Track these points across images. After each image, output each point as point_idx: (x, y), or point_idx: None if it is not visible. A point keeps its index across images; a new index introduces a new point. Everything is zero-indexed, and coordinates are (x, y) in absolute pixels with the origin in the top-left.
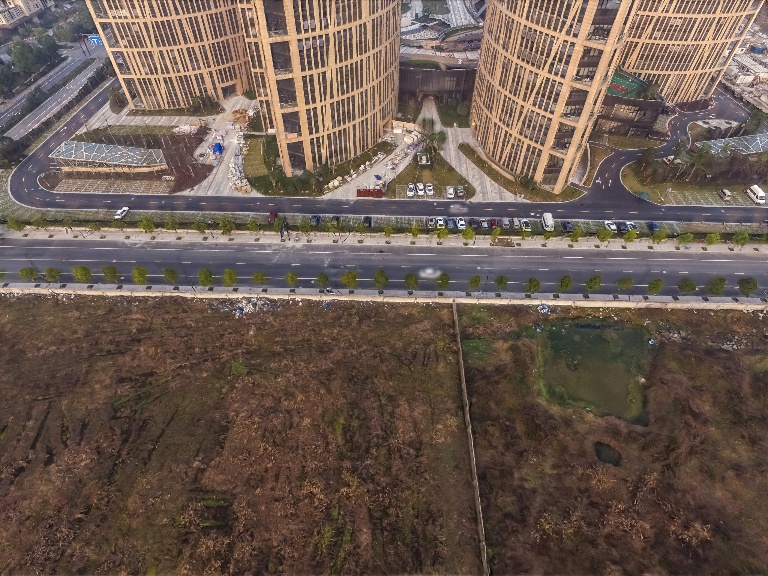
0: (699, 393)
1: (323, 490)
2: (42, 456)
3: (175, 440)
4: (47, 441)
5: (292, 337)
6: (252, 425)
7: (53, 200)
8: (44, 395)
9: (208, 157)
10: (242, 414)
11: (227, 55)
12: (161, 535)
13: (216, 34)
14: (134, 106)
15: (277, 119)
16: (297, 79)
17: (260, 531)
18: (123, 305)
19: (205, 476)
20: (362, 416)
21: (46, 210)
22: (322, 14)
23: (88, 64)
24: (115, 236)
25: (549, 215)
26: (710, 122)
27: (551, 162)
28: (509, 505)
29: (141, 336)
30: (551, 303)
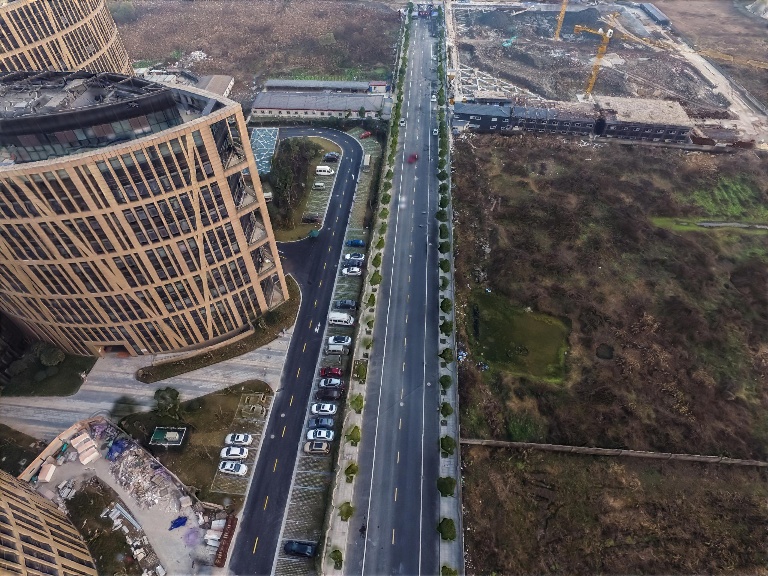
0: (537, 280)
1: None
2: None
3: None
4: None
5: None
6: None
7: None
8: None
9: None
10: None
11: None
12: None
13: None
14: None
15: None
16: None
17: None
18: None
19: None
20: (639, 571)
21: None
22: None
23: None
24: None
25: (334, 314)
26: None
27: None
28: (676, 433)
29: None
30: None
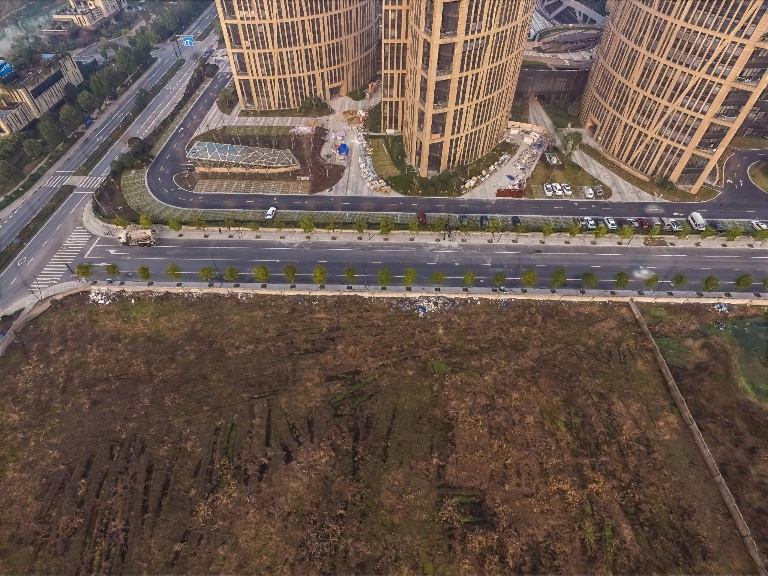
0: None
1: (571, 486)
2: (280, 453)
3: (405, 437)
4: (279, 438)
5: (483, 336)
6: (477, 422)
7: (197, 200)
8: (259, 393)
9: (335, 157)
10: (462, 412)
11: (339, 56)
12: (426, 531)
13: (332, 35)
14: (244, 107)
15: (427, 120)
16: (454, 80)
17: (522, 527)
18: (304, 304)
19: (448, 473)
20: (581, 413)
21: (193, 210)
22: (489, 16)
23: (180, 65)
24: (270, 236)
25: (698, 215)
26: None
27: (689, 162)
28: (757, 501)
29: (333, 335)
30: (727, 302)
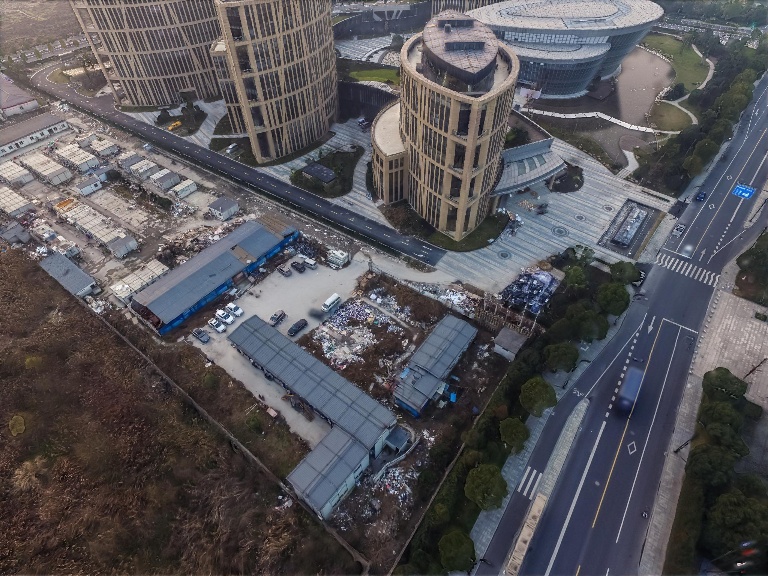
0: None
1: None
2: None
3: None
4: None
5: None
6: None
7: None
8: None
9: None
10: None
11: None
12: None
13: None
14: None
15: None
16: None
17: None
18: None
19: None
20: None
21: None
22: None
23: None
24: None
25: None
26: (116, 88)
27: None
28: None
29: None
30: None
